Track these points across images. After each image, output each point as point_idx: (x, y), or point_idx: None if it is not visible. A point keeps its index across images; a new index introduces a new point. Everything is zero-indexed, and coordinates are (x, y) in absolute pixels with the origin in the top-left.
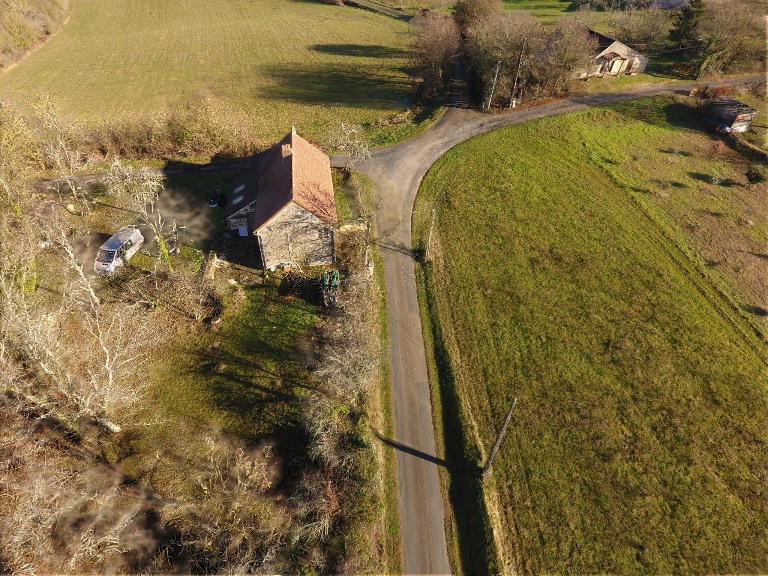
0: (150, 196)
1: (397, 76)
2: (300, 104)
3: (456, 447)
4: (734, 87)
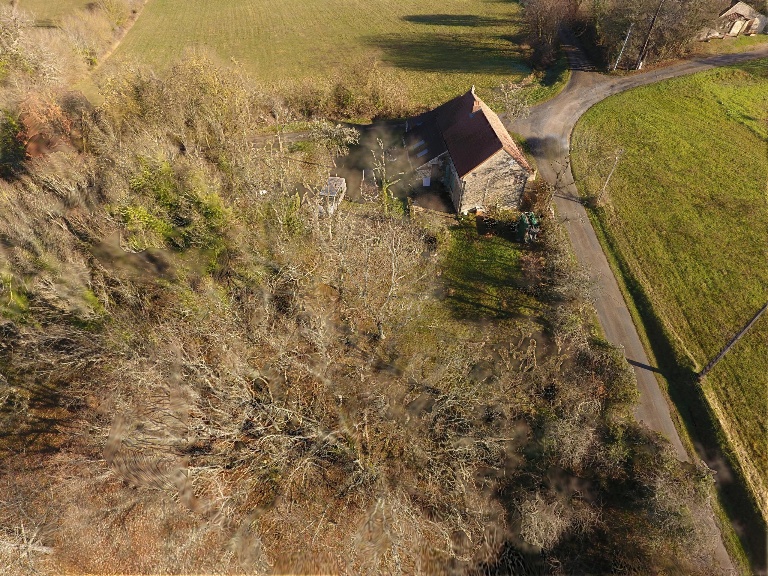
0: (348, 150)
1: (501, 43)
2: (419, 72)
3: (666, 358)
4: None
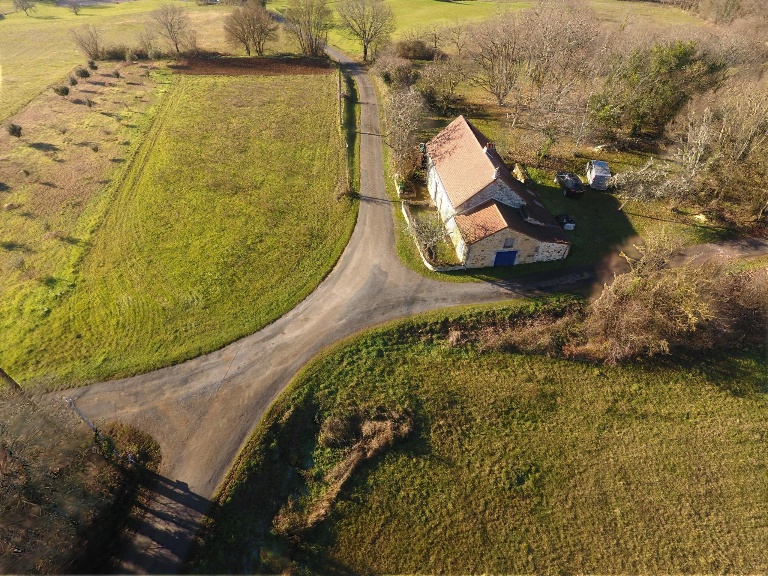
0: None
1: None
2: None
3: None
4: None
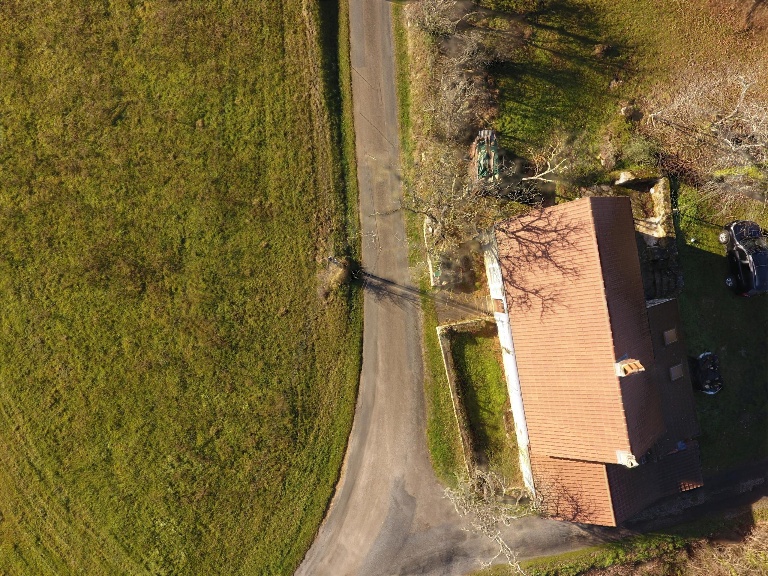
0: None
1: None
2: None
3: None
4: None
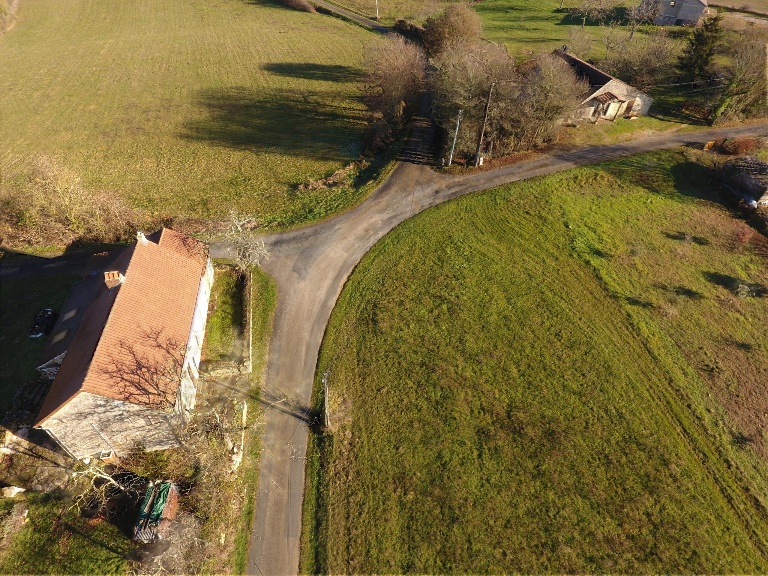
0: None
1: (354, 108)
2: (226, 148)
3: None
4: (759, 137)
